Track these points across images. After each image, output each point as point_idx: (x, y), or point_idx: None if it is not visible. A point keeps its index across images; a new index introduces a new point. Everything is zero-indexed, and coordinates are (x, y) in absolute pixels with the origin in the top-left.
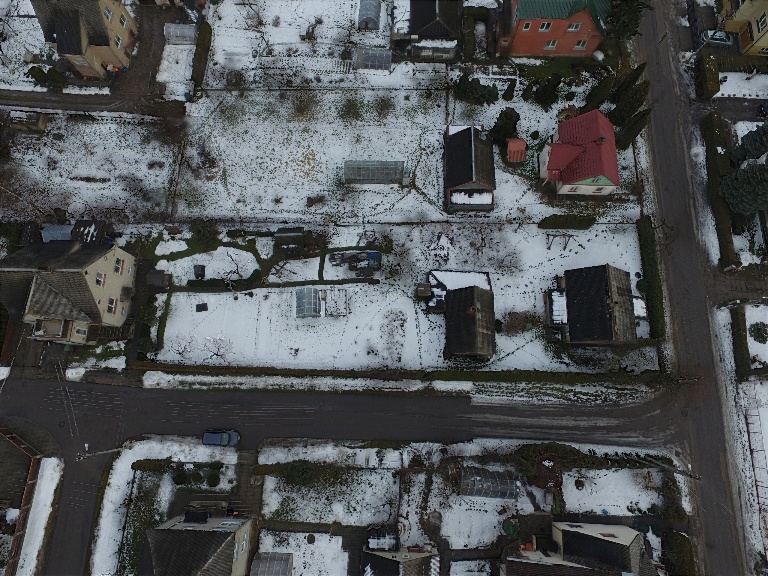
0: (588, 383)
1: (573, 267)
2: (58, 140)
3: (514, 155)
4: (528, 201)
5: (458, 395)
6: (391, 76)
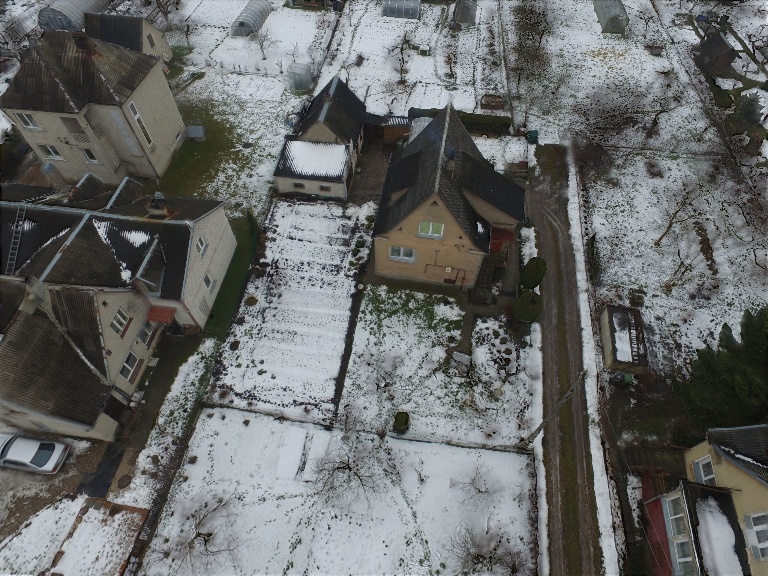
0: None
1: None
2: (643, 298)
3: None
4: None
5: None
6: (483, 5)
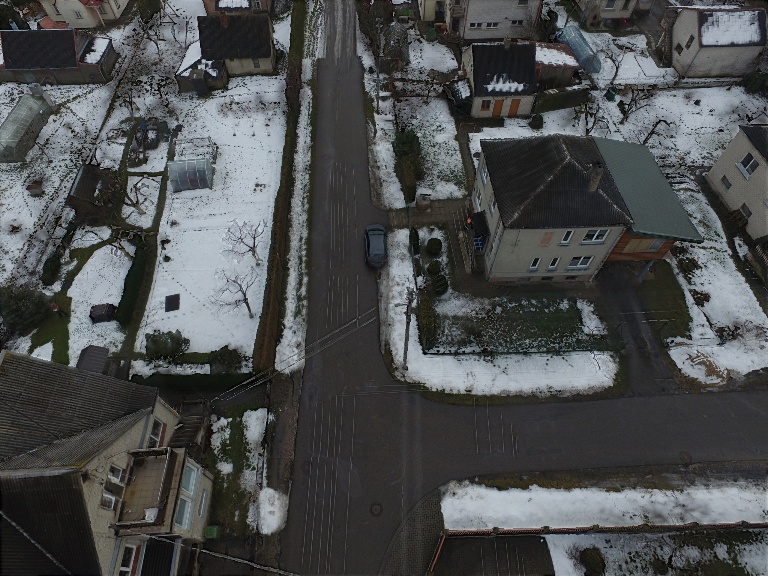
0: (306, 6)
1: (198, 13)
2: None
3: (58, 28)
4: (118, 35)
5: (316, 65)
6: None
